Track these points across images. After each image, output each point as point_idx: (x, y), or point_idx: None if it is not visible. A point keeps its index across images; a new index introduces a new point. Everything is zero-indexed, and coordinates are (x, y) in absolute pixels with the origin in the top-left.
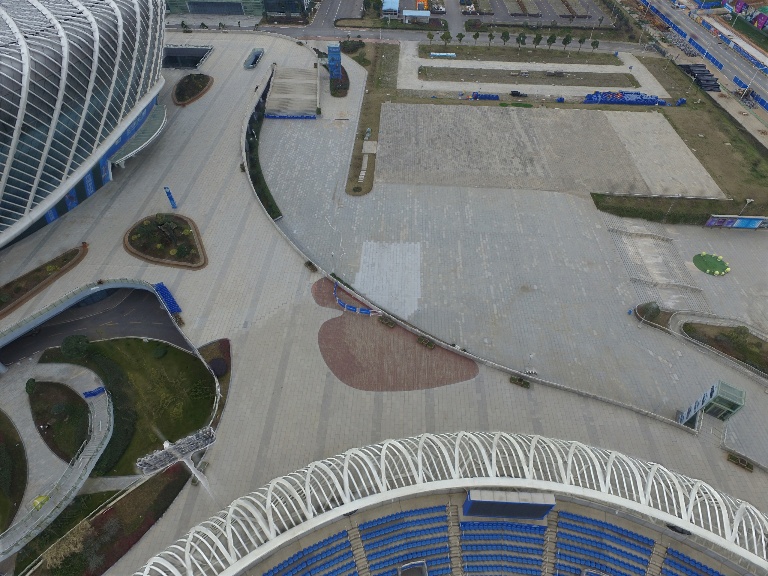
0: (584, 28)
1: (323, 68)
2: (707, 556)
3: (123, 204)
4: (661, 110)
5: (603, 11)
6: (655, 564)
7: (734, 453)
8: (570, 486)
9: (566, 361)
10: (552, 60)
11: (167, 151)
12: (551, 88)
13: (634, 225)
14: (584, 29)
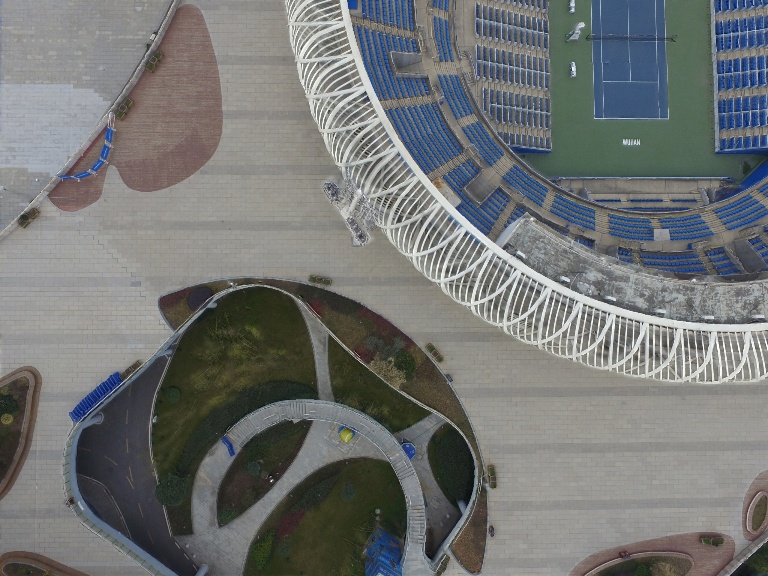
0: None
1: None
2: None
3: None
4: None
5: None
6: None
7: None
8: None
9: None
10: None
11: None
12: None
13: None
14: None
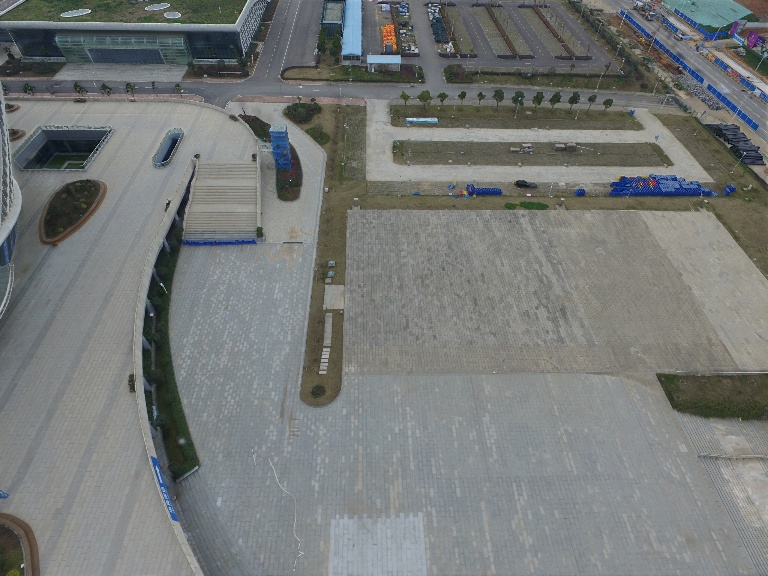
0: (588, 75)
1: None
2: None
3: None
4: (710, 206)
5: (604, 49)
6: None
7: None
8: None
9: None
10: (557, 124)
11: (13, 349)
12: (564, 171)
13: (728, 434)
14: (588, 77)
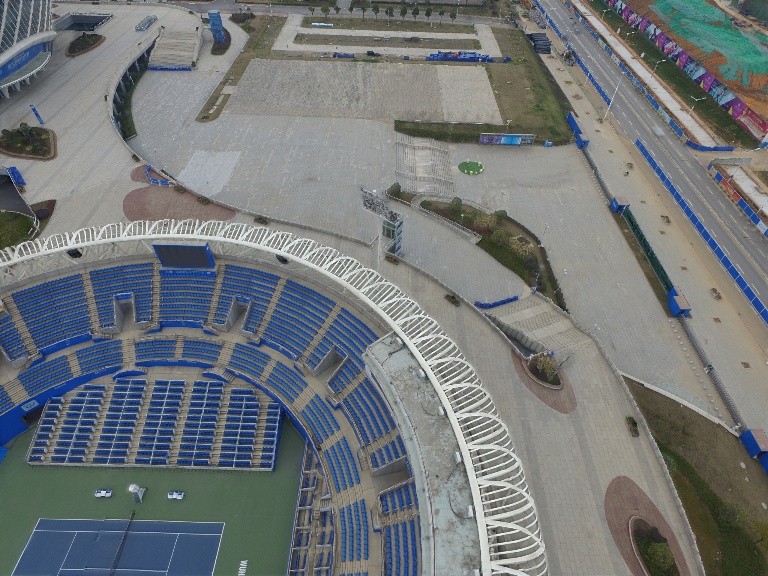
0: (454, 5)
1: (212, 34)
2: (309, 283)
3: (1, 121)
4: (486, 65)
5: None
6: (279, 290)
7: (389, 255)
8: (218, 237)
9: (319, 221)
10: (416, 29)
11: (49, 87)
12: (404, 50)
13: (421, 142)
14: (454, 6)
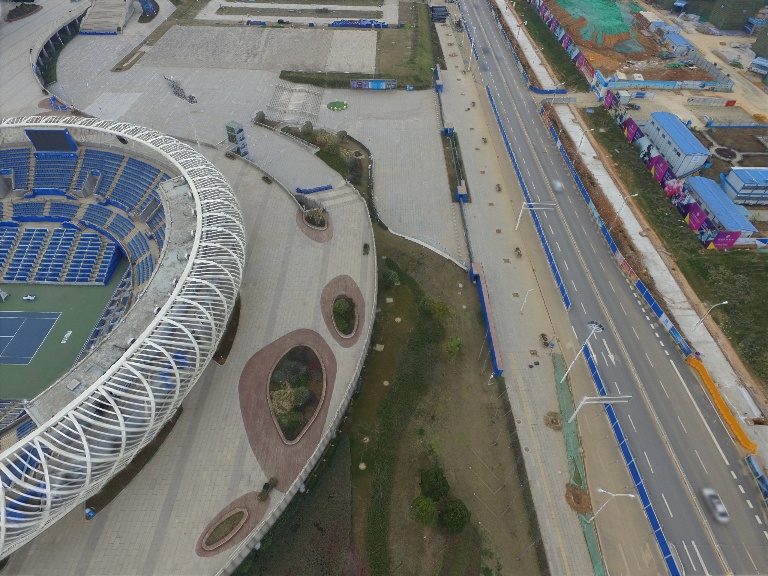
0: None
1: None
2: (145, 159)
3: None
4: (379, 30)
5: None
6: (123, 166)
7: None
8: None
9: None
10: (329, 3)
11: None
12: (312, 19)
13: (300, 87)
14: None
